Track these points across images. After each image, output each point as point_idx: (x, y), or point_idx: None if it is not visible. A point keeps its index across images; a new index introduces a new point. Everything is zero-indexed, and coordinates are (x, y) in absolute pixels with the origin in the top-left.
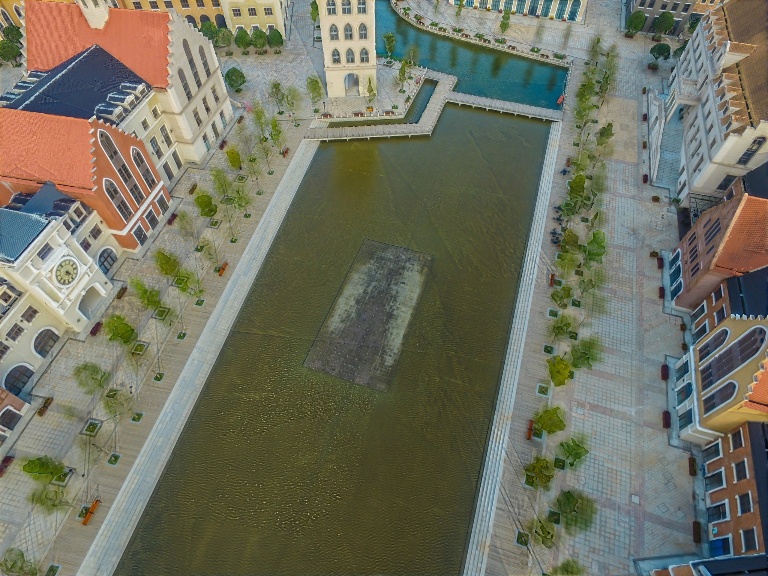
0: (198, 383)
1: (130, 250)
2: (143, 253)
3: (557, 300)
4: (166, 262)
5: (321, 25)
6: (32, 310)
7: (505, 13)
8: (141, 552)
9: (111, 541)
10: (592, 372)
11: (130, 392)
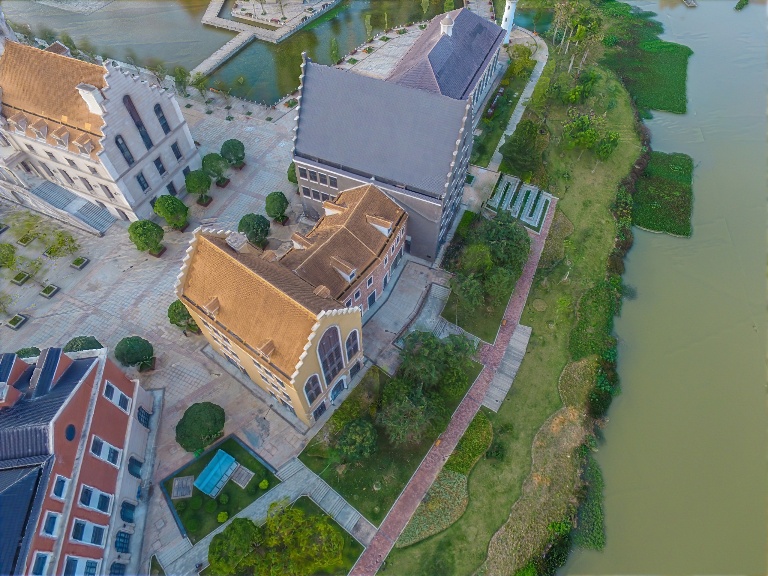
0: None
1: None
2: None
3: None
4: None
5: None
6: None
7: None
8: None
9: None
10: None
11: None
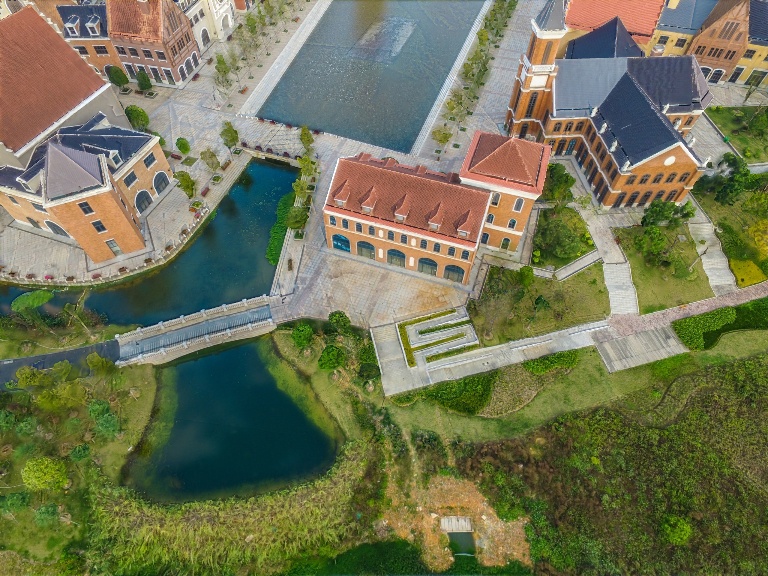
0: (289, 59)
1: (241, 11)
2: (248, 14)
3: None
4: (268, 4)
5: None
6: (202, 12)
7: None
8: (271, 106)
9: (256, 101)
10: (505, 58)
11: (254, 58)
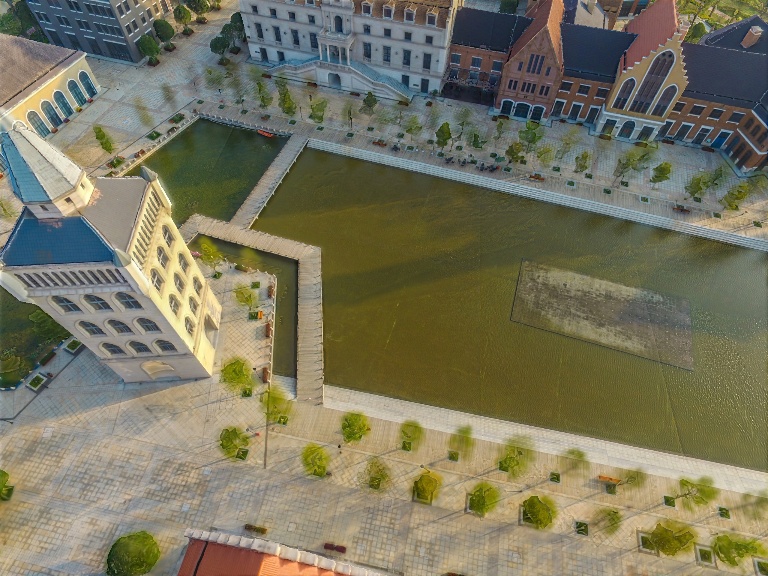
0: (764, 478)
1: None
2: None
3: (578, 170)
4: None
5: (164, 316)
6: None
7: (98, 132)
8: None
9: None
10: None
11: None
